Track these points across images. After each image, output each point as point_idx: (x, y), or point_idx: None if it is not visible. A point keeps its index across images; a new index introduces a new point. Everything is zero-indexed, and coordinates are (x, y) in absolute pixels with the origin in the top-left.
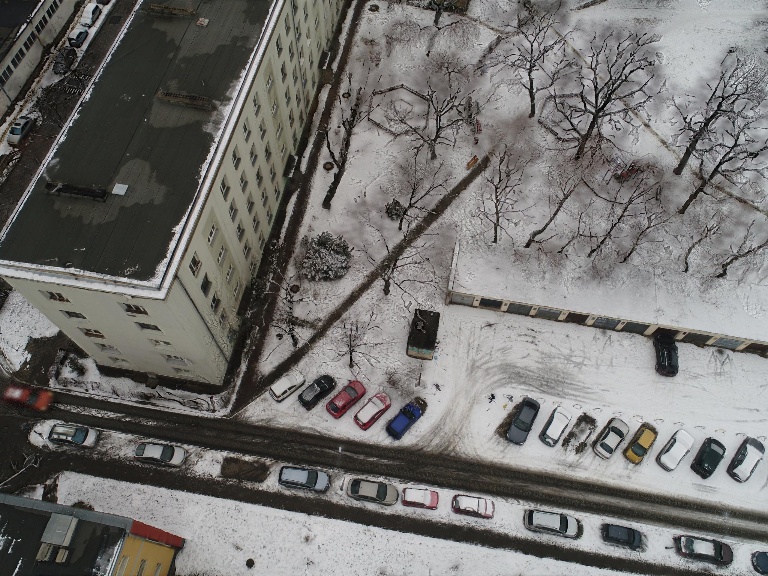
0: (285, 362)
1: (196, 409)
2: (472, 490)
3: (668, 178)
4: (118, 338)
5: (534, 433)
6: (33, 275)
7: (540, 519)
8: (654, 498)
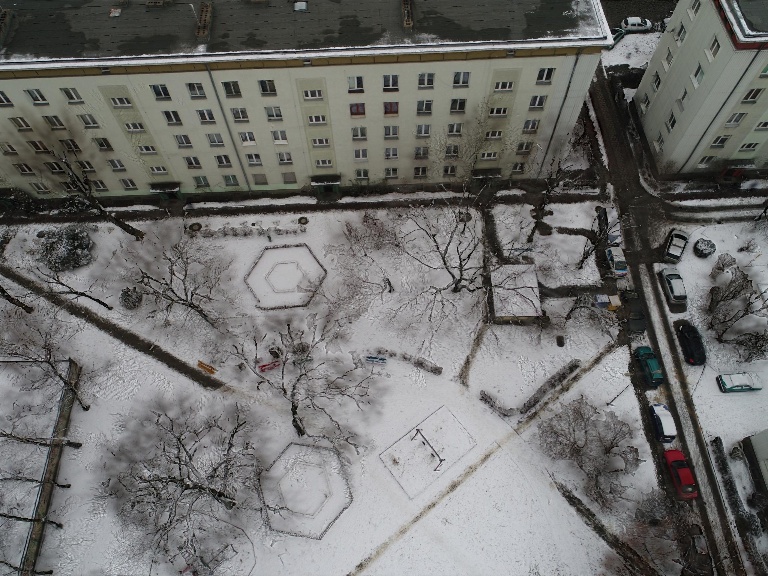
0: None
1: None
2: None
3: None
4: None
5: None
6: None
7: None
8: None
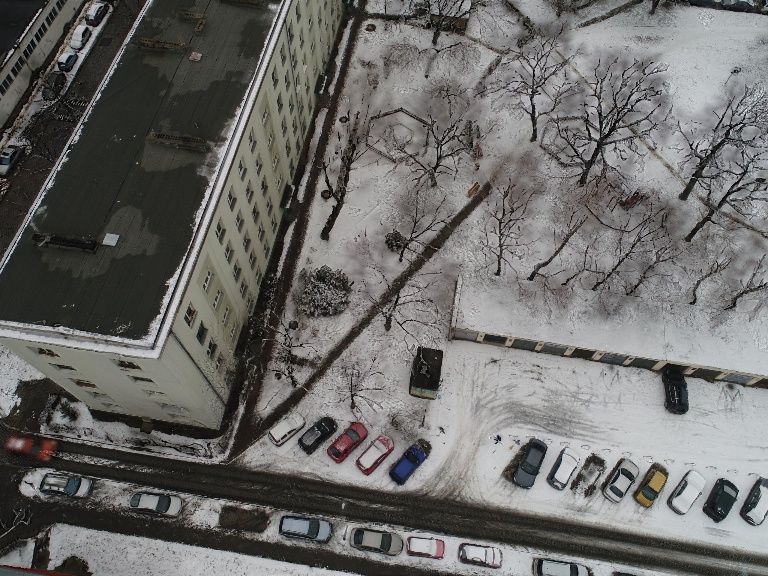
0: (284, 403)
1: (193, 455)
2: (479, 537)
3: (673, 204)
4: (111, 388)
5: (542, 476)
6: (20, 334)
7: (550, 569)
8: (666, 543)
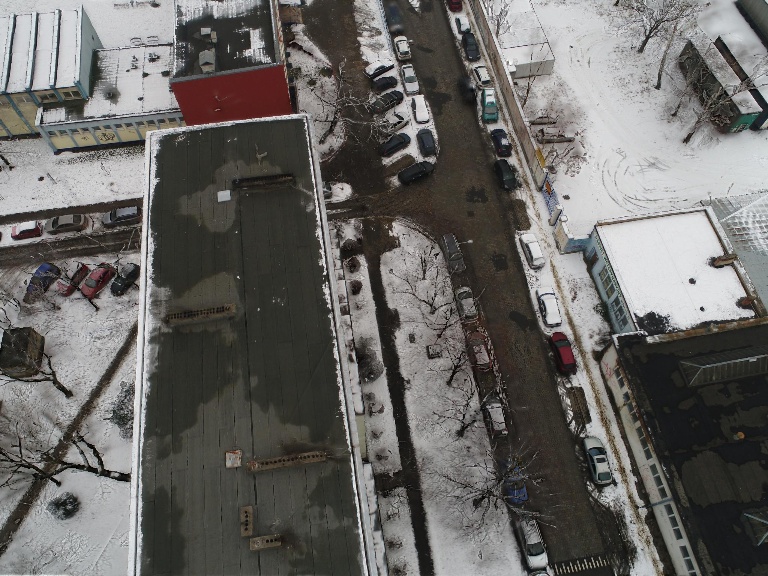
0: None
1: None
2: None
3: None
4: None
5: None
6: None
7: None
8: None
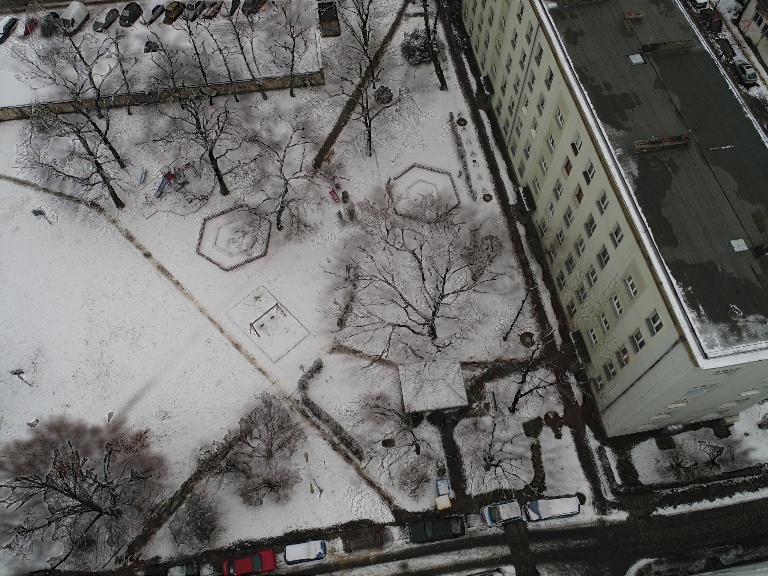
0: None
1: None
2: None
3: (132, 197)
4: None
5: None
6: None
7: None
8: None
